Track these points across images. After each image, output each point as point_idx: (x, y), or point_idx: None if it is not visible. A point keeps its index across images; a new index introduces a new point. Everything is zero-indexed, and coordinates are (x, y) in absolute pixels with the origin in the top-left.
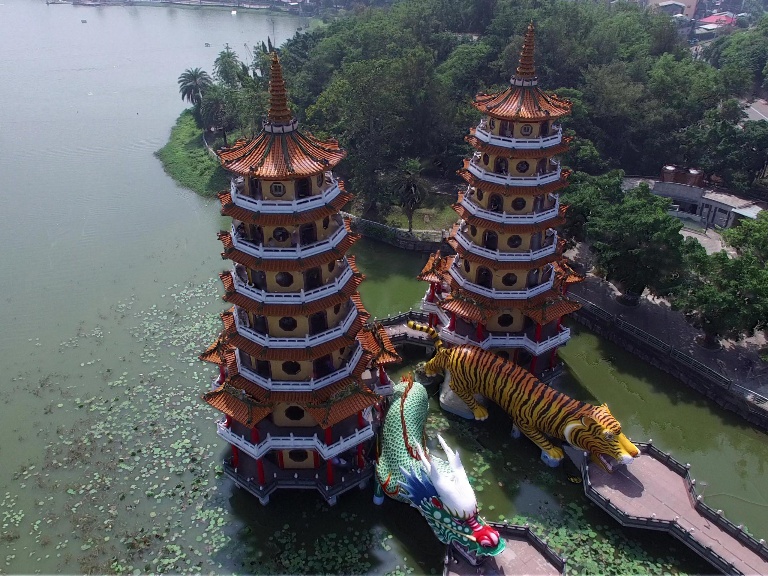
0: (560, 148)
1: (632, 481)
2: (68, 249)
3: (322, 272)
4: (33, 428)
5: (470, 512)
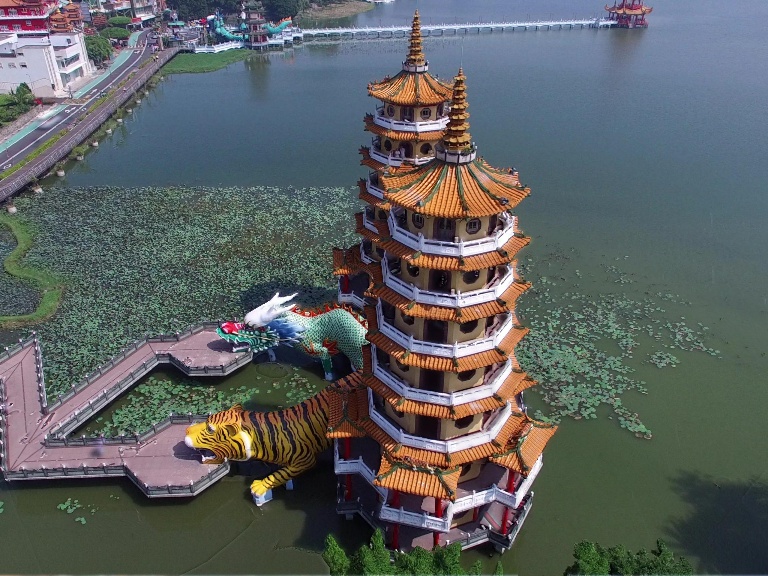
0: None
1: (188, 454)
2: None
3: None
4: None
5: None
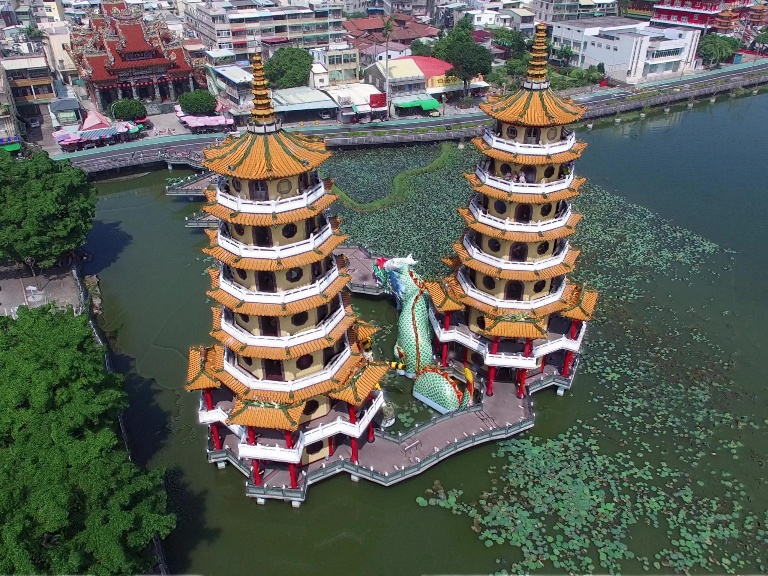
0: None
1: None
2: None
3: None
4: (767, 399)
5: None
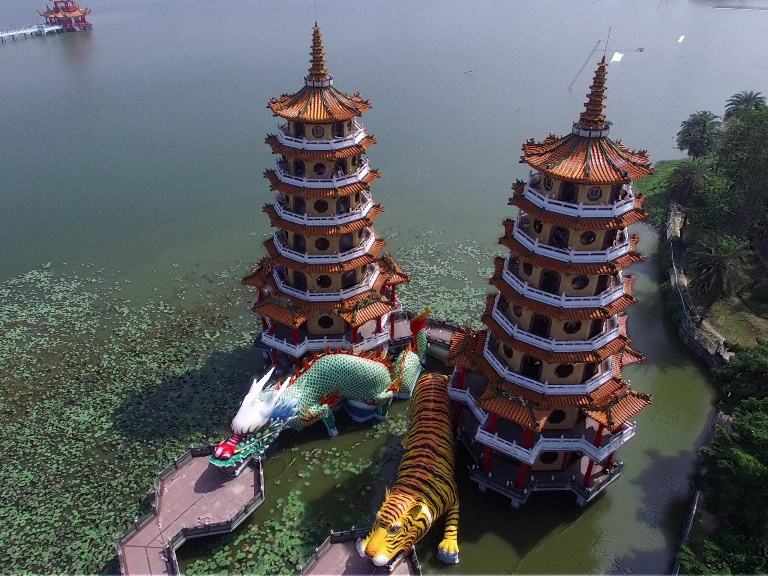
0: (569, 221)
1: None
2: (427, 175)
3: (307, 206)
4: None
5: (235, 428)
